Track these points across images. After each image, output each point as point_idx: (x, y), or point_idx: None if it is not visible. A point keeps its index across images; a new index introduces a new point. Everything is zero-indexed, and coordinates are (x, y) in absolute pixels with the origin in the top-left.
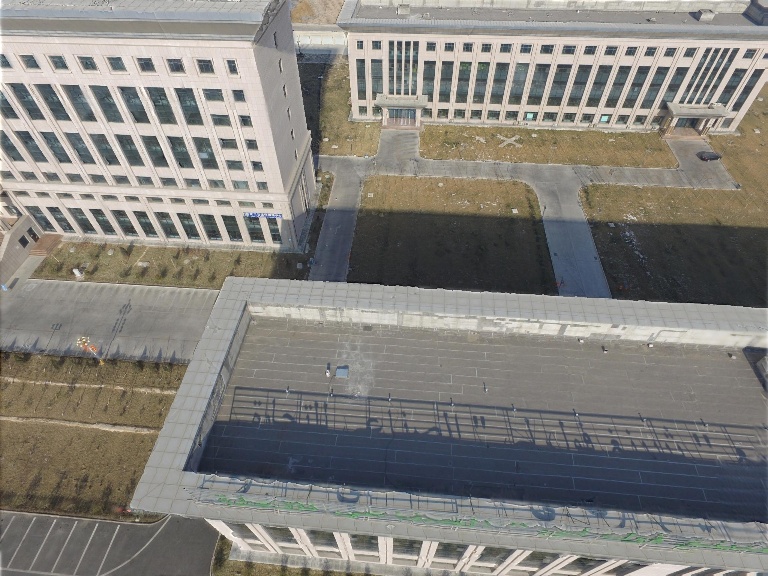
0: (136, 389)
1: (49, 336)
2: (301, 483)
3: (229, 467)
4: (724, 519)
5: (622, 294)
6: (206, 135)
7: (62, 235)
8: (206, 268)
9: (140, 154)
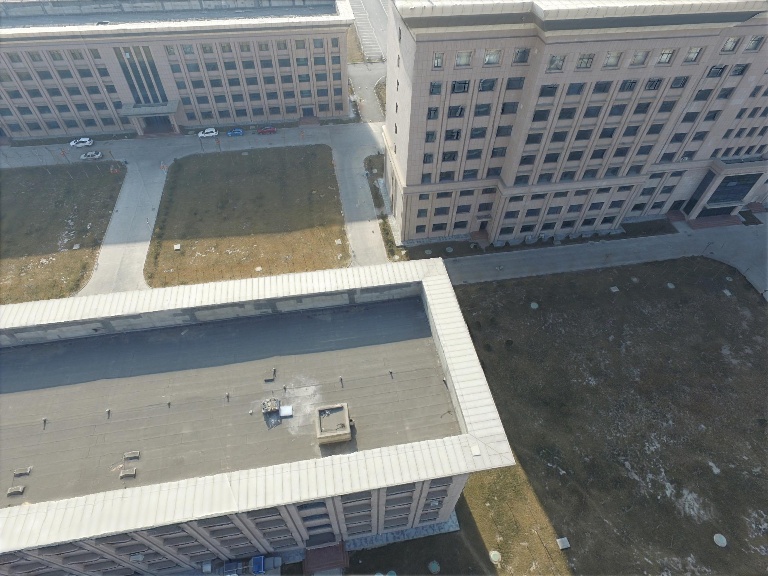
0: None
1: None
2: (300, 9)
3: (325, 8)
4: (159, 14)
5: (113, 187)
6: None
7: None
8: None
9: None
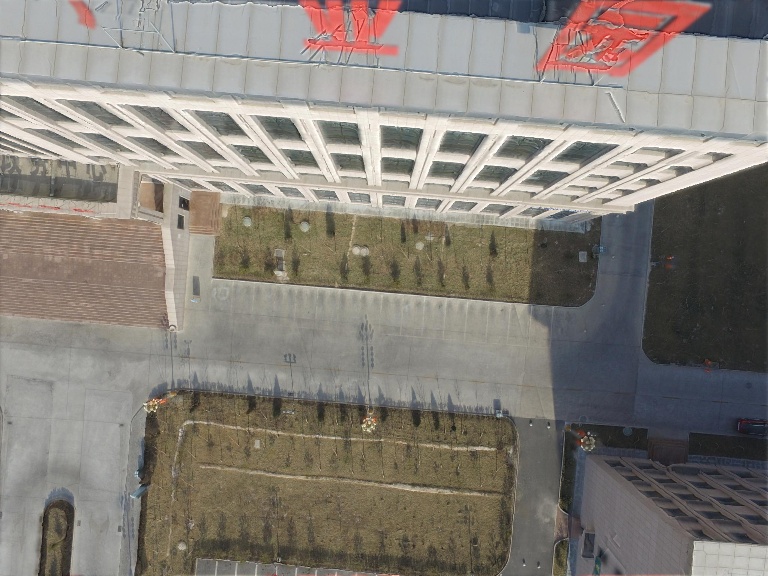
0: (421, 445)
1: (288, 373)
2: None
3: None
4: None
5: None
6: (567, 170)
7: (218, 192)
8: (451, 259)
9: (413, 172)
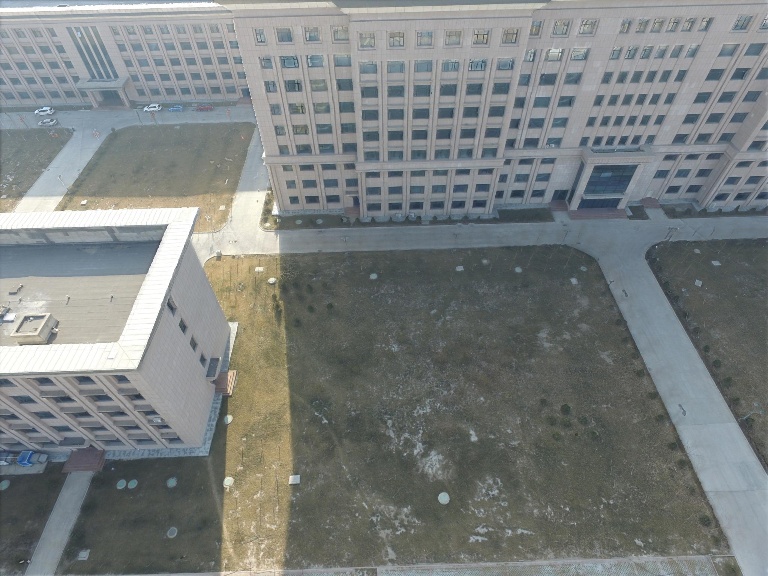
0: None
1: None
2: None
3: None
4: None
5: (54, 150)
6: None
7: None
8: None
9: None
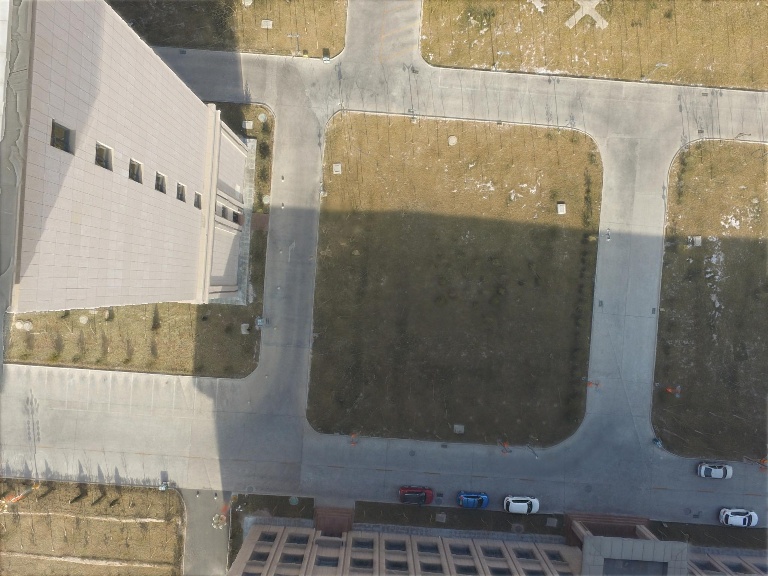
0: (89, 517)
1: None
2: None
3: None
4: None
5: (668, 376)
6: None
7: None
8: (115, 333)
9: None
